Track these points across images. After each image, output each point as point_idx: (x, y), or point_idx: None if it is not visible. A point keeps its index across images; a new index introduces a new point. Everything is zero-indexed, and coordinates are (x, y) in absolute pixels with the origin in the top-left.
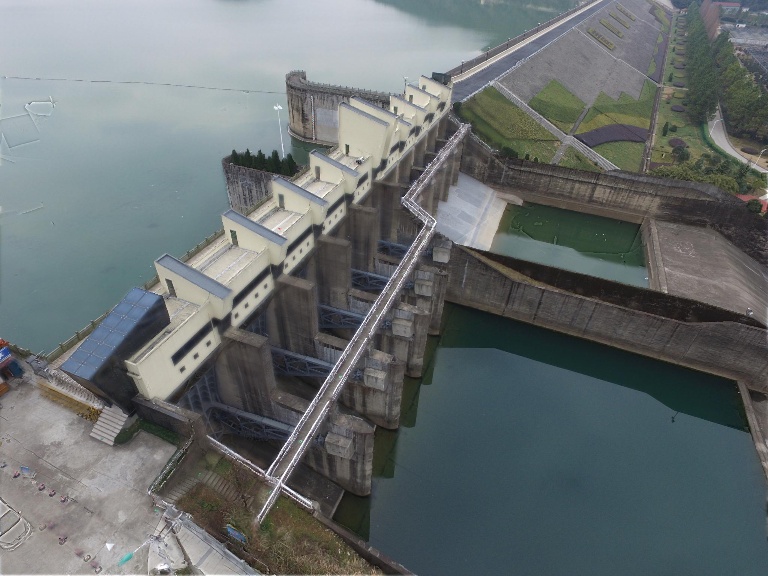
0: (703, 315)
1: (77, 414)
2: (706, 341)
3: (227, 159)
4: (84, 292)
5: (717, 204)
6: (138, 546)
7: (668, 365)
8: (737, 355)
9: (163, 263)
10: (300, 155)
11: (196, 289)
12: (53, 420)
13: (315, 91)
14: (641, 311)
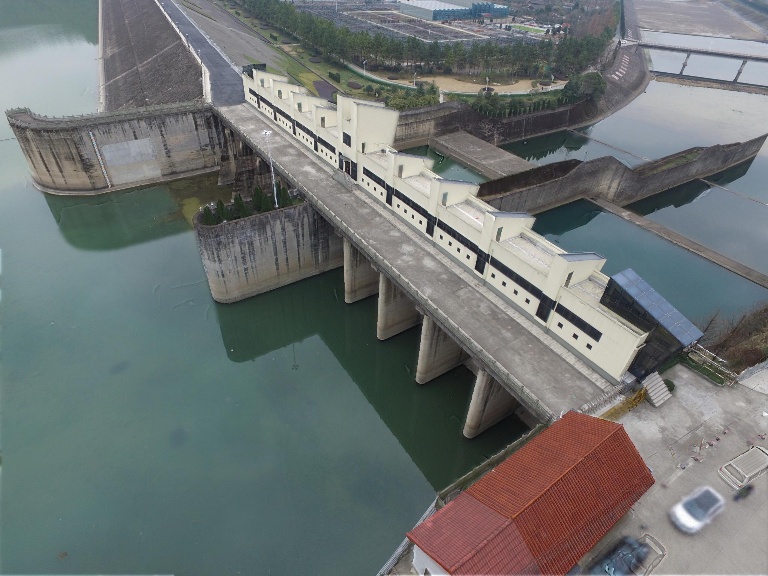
0: (559, 170)
1: (629, 411)
2: (573, 182)
3: (199, 223)
4: (206, 473)
5: (459, 113)
6: (766, 400)
7: (559, 208)
8: (584, 182)
9: (567, 260)
10: (122, 209)
11: (591, 264)
12: (631, 428)
13: (93, 125)
14: (547, 182)
